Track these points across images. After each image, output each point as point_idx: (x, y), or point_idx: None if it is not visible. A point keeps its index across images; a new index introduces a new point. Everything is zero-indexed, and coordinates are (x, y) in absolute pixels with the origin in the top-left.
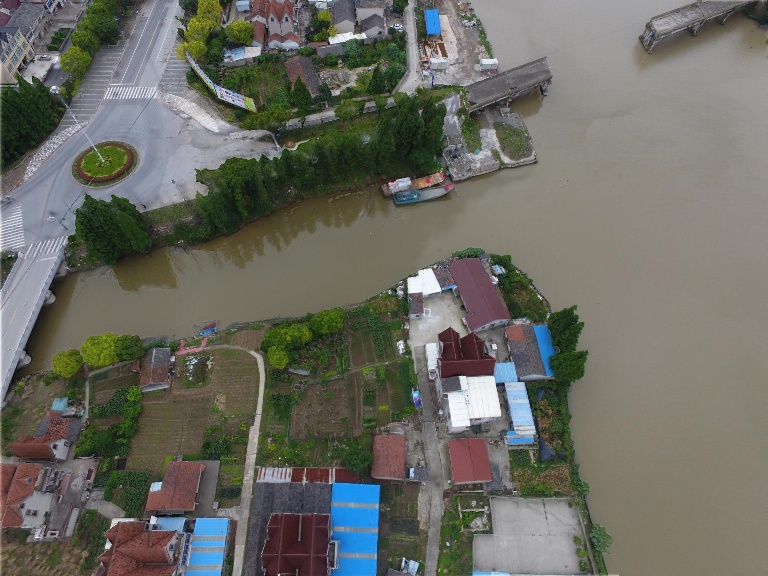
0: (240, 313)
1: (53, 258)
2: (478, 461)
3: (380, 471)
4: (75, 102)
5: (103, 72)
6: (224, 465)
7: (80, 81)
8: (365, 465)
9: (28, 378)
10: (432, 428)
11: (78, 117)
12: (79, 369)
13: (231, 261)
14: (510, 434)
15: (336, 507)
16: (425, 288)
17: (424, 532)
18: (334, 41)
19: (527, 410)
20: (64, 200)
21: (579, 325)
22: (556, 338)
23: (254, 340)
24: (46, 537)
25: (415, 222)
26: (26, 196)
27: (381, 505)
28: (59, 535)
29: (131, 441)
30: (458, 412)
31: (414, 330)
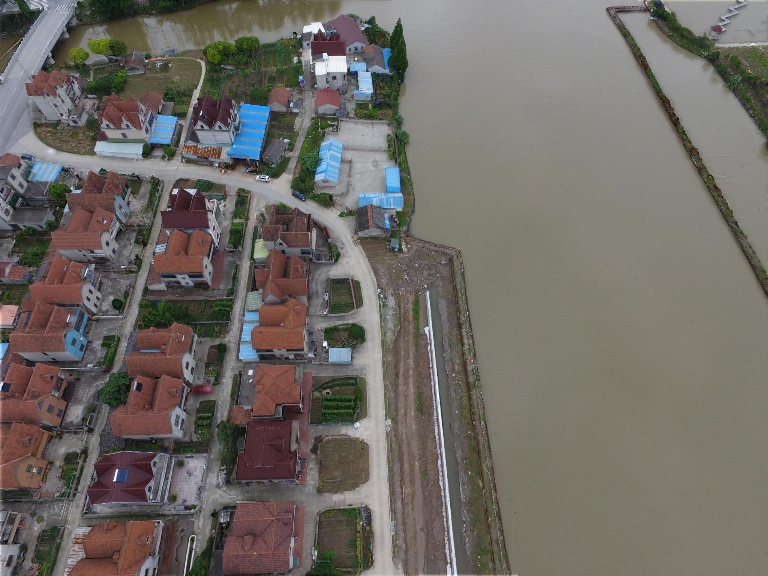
0: (192, 46)
1: (67, 12)
2: (332, 97)
3: (271, 101)
4: None
5: None
6: (177, 105)
7: None
8: (262, 95)
9: (53, 69)
10: (309, 93)
11: None
12: (86, 65)
13: (191, 42)
14: (356, 91)
15: (242, 112)
16: (314, 30)
17: (297, 132)
18: None
19: (370, 83)
20: None
21: (400, 27)
22: (392, 46)
23: (200, 55)
24: (69, 118)
25: (318, 12)
26: None
27: (272, 122)
28: (77, 118)
29: (119, 94)
30: (320, 69)
31: (305, 53)
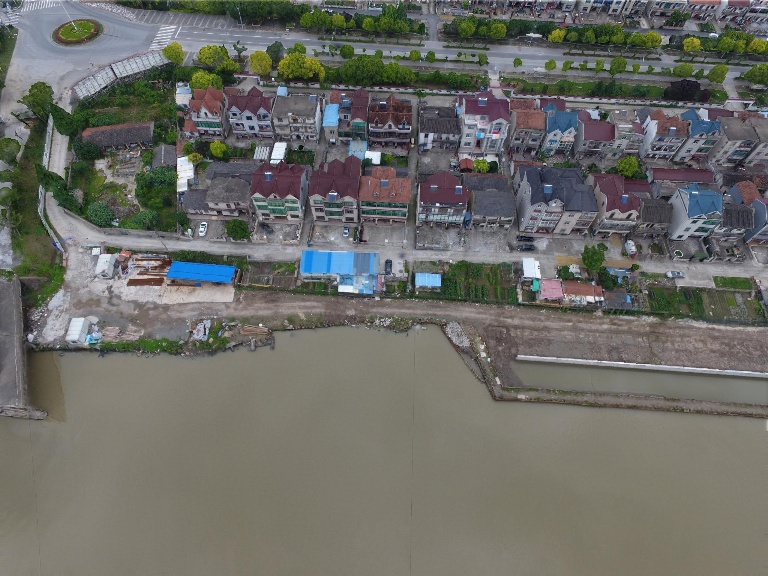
0: None
1: None
2: None
3: None
4: (164, 13)
5: (200, 22)
6: None
7: (190, 12)
8: None
9: None
10: None
11: (144, 16)
12: None
13: None
14: None
15: None
16: None
17: None
18: (181, 161)
19: None
20: (52, 20)
21: None
22: None
23: None
24: None
25: None
26: (68, 6)
27: None
28: None
29: None
30: None
31: None
